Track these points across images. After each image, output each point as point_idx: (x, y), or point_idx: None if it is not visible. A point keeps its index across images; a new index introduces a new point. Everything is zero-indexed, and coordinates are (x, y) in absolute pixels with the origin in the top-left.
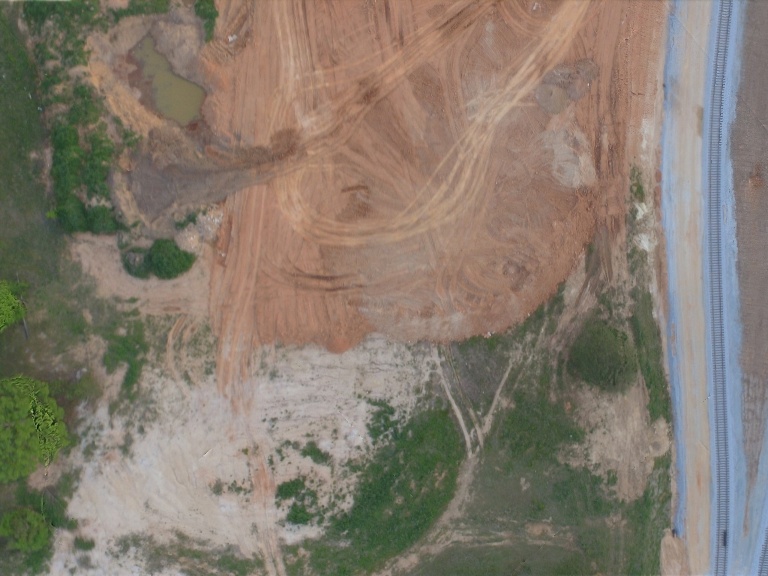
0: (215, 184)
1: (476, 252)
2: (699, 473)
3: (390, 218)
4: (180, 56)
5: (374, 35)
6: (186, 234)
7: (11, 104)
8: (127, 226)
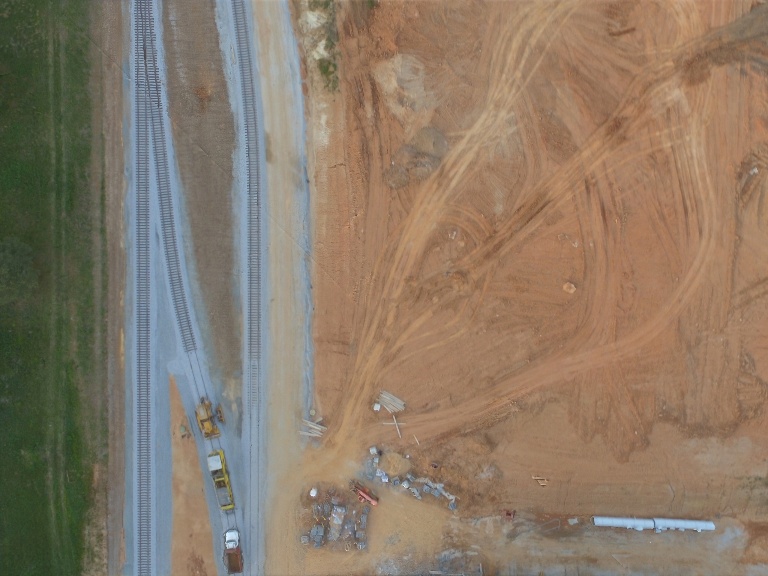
0: (764, 22)
1: None
2: None
3: (586, 5)
4: None
5: (616, 187)
6: None
7: None
8: None
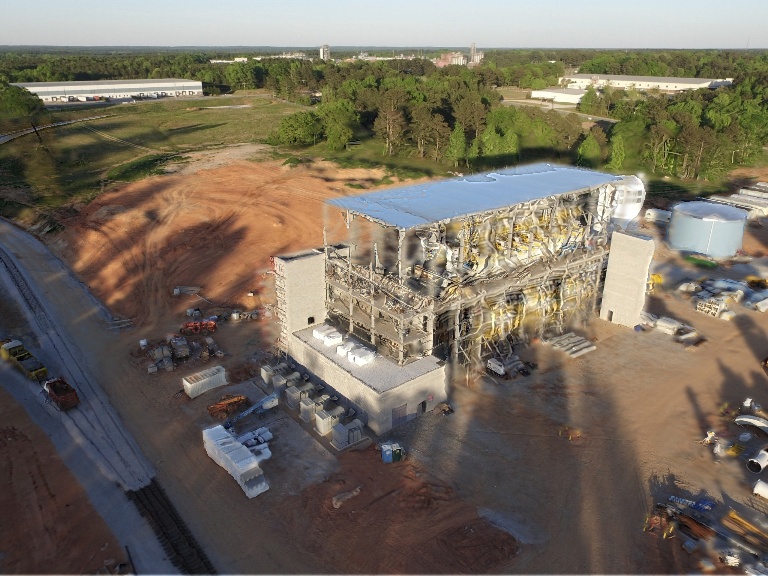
0: None
1: None
2: None
3: None
4: None
5: None
6: None
7: None
8: None
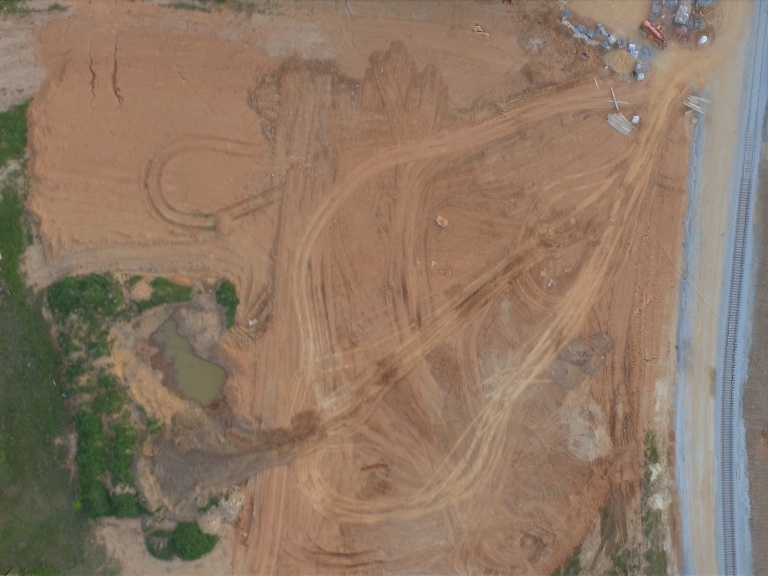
0: (237, 467)
1: (494, 527)
2: None
3: (409, 495)
4: (202, 342)
5: (392, 317)
6: (209, 518)
7: (36, 392)
8: (151, 512)
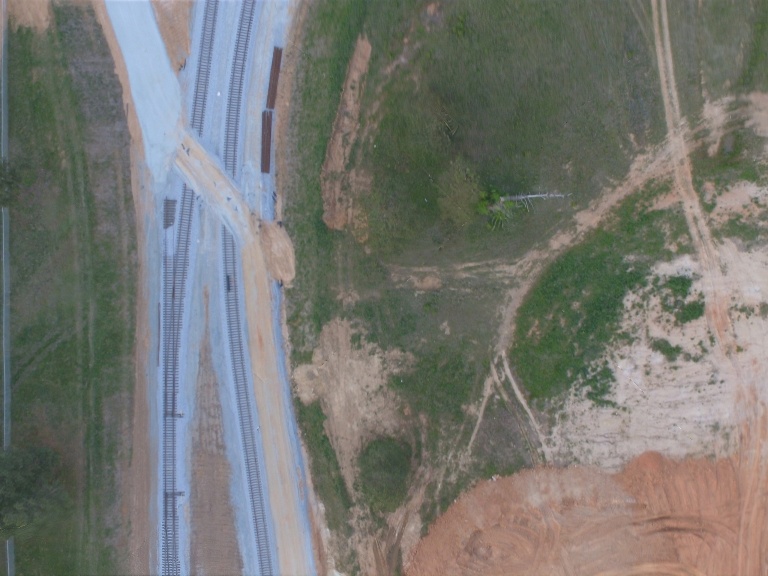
0: None
1: (523, 568)
2: (262, 349)
3: None
4: None
5: None
6: None
7: None
8: None
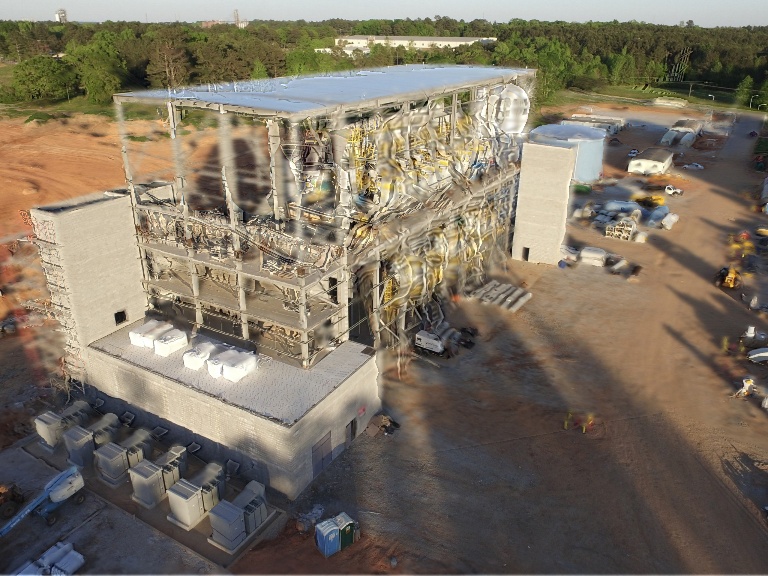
0: (48, 128)
1: None
2: None
3: None
4: None
5: None
6: None
7: None
8: None
